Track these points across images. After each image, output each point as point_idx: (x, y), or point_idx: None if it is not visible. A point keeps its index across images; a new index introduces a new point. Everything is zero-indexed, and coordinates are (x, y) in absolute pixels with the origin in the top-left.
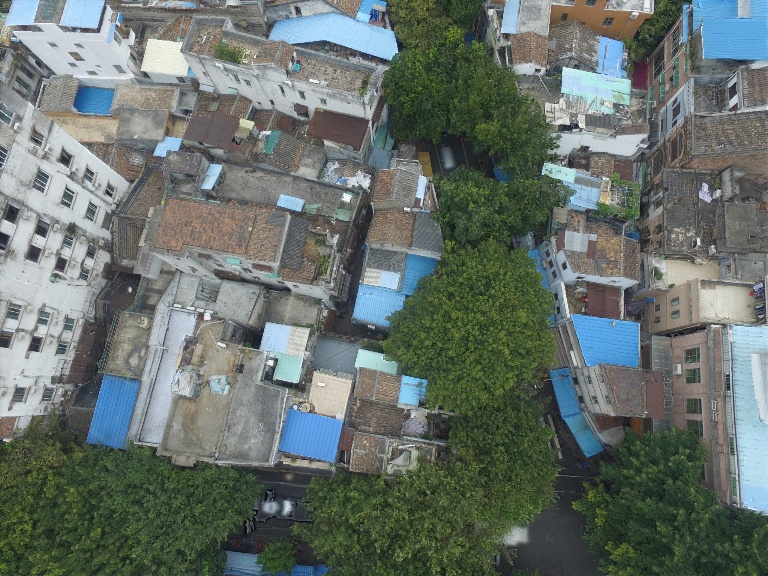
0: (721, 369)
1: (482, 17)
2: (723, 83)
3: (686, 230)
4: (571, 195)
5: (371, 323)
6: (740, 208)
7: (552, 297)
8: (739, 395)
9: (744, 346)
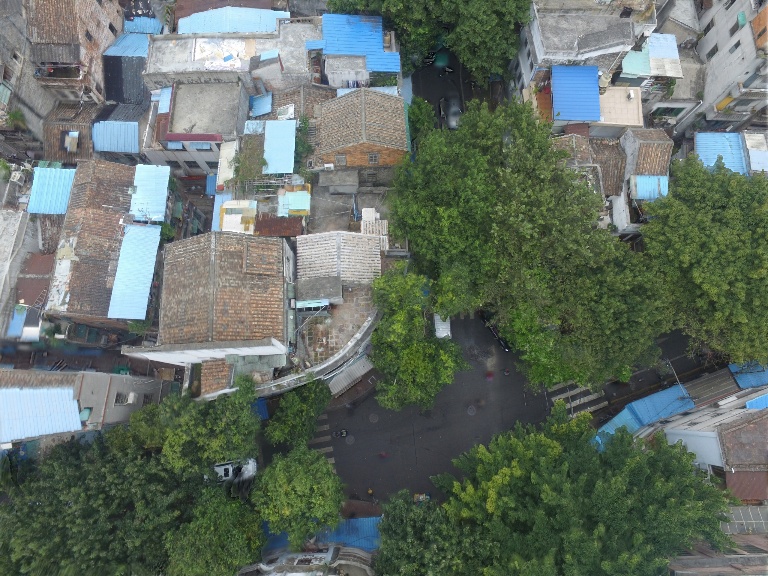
0: None
1: None
2: None
3: None
4: None
5: (695, 153)
6: None
7: None
8: None
9: None
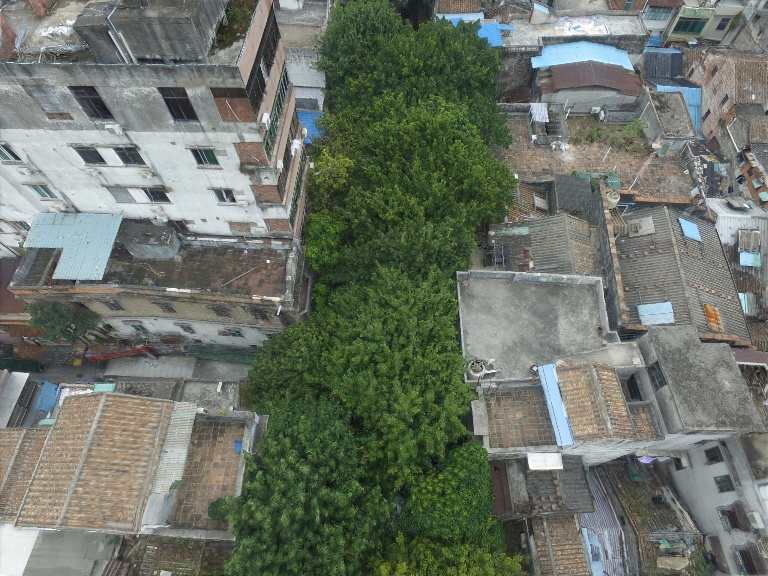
0: None
1: None
2: None
3: None
4: None
5: None
6: None
7: None
8: None
9: None
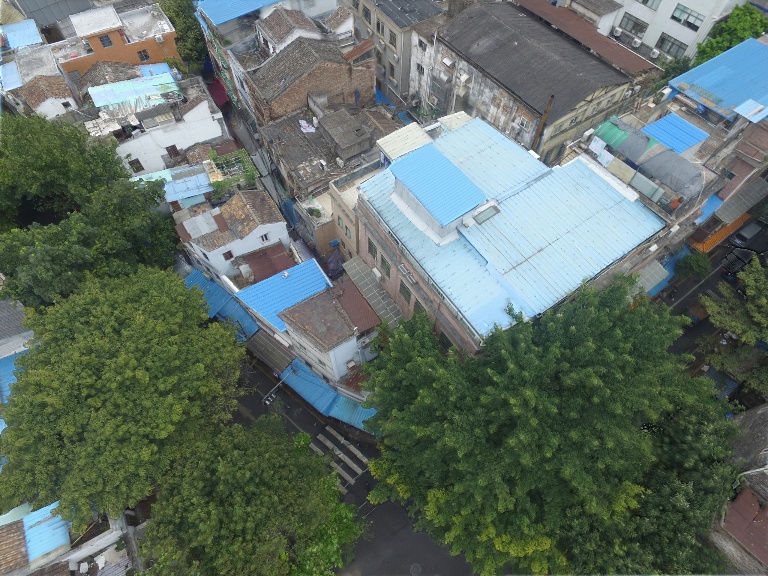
0: (383, 232)
1: (8, 103)
2: (257, 43)
3: (309, 162)
4: (162, 185)
5: None
6: (334, 117)
7: (237, 302)
8: (405, 238)
9: (379, 195)
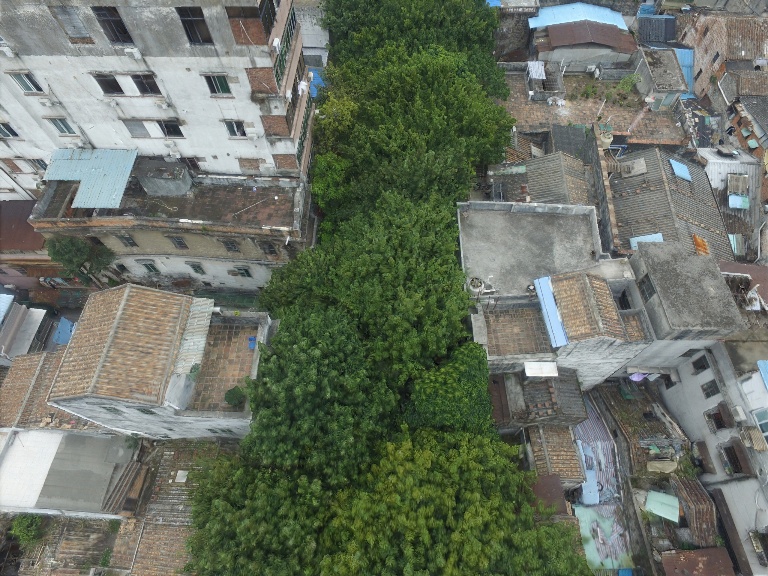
0: None
1: None
2: None
3: None
4: None
5: None
6: None
7: None
8: None
9: None
